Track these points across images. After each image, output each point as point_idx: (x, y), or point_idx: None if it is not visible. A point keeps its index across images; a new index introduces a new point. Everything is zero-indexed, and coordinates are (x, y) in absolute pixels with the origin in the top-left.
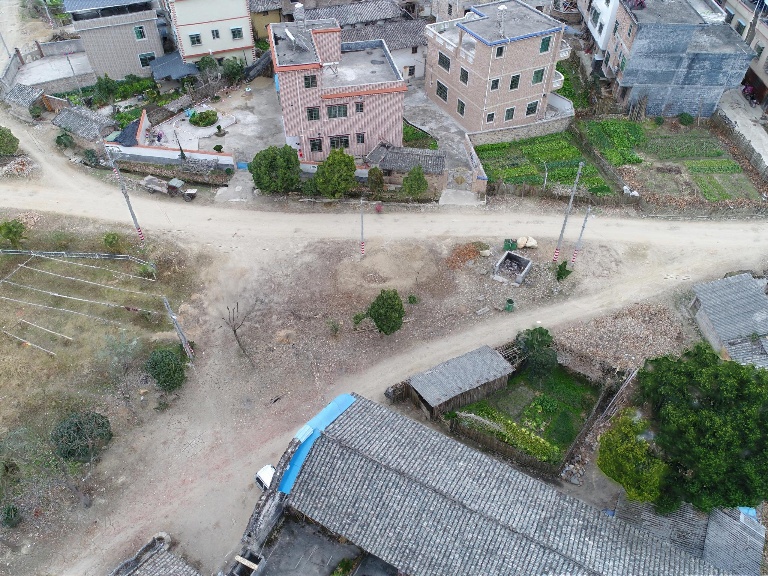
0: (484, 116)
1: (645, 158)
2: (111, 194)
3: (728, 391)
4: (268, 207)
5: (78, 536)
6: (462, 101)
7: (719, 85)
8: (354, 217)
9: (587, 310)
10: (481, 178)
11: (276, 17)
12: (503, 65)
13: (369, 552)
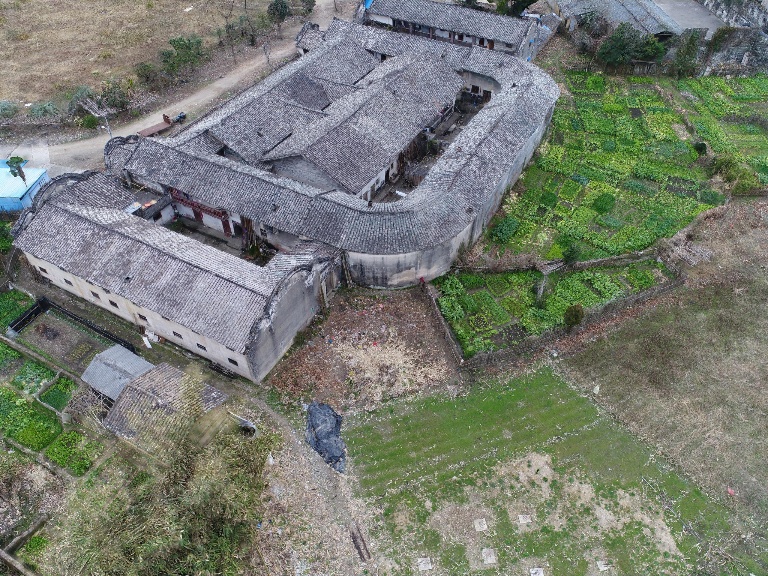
0: None
1: None
2: None
3: None
4: None
5: (280, 46)
6: None
7: None
8: None
9: None
10: None
11: None
12: None
13: (399, 19)
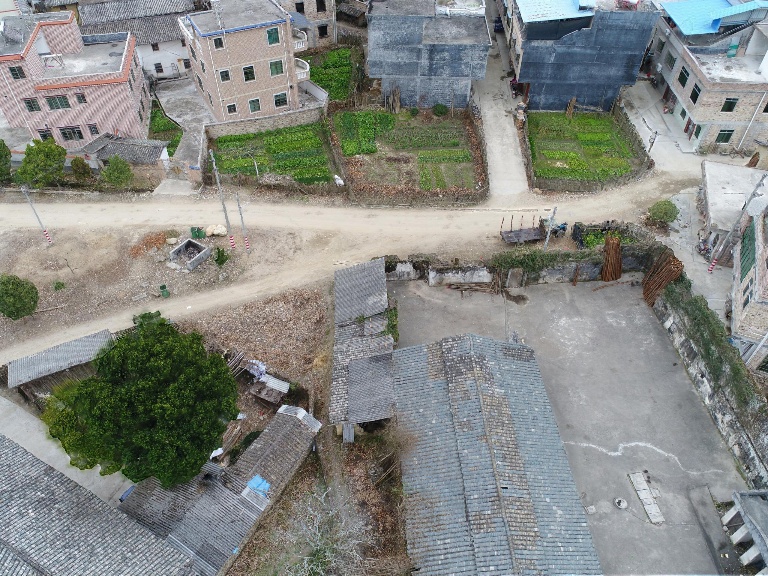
0: (223, 107)
1: (383, 148)
2: None
3: (133, 364)
4: None
5: None
6: (209, 93)
7: (465, 76)
8: (63, 207)
9: (242, 295)
10: (193, 168)
11: (75, 11)
12: (228, 56)
13: None
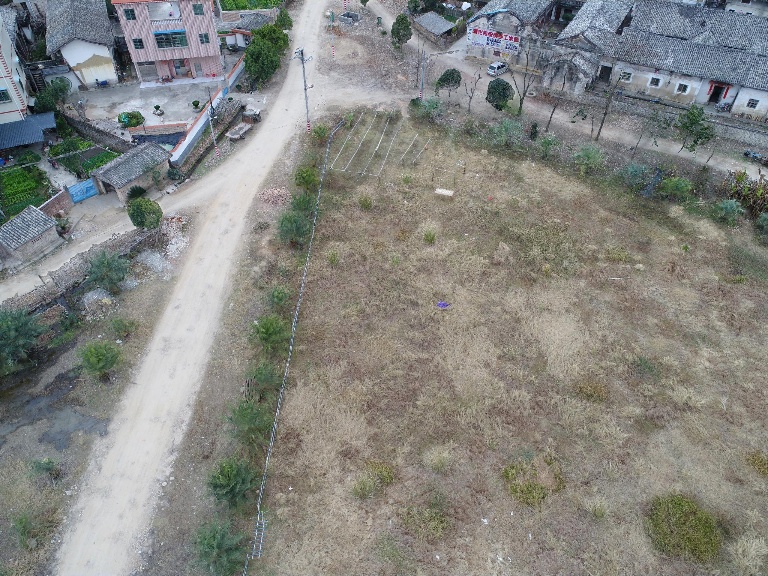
0: None
1: None
2: (240, 159)
3: None
4: (276, 89)
5: None
6: None
7: None
8: (294, 60)
9: (380, 8)
10: (277, 10)
11: None
12: None
13: None
